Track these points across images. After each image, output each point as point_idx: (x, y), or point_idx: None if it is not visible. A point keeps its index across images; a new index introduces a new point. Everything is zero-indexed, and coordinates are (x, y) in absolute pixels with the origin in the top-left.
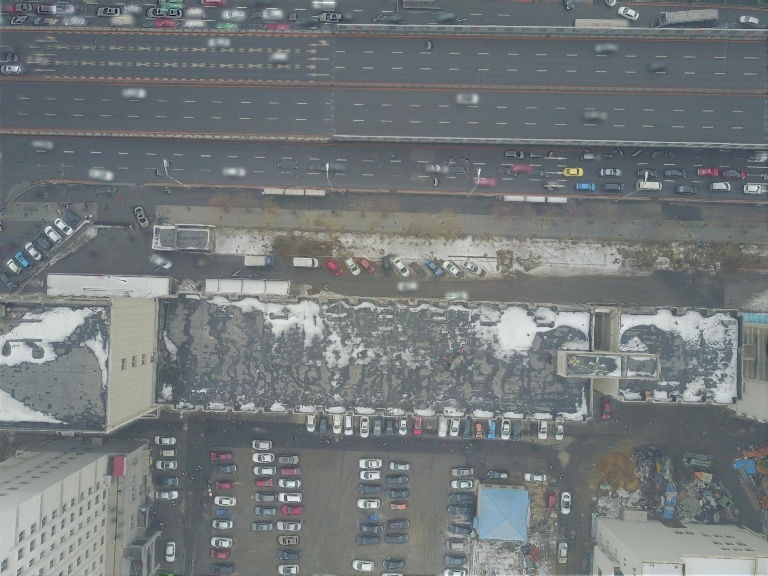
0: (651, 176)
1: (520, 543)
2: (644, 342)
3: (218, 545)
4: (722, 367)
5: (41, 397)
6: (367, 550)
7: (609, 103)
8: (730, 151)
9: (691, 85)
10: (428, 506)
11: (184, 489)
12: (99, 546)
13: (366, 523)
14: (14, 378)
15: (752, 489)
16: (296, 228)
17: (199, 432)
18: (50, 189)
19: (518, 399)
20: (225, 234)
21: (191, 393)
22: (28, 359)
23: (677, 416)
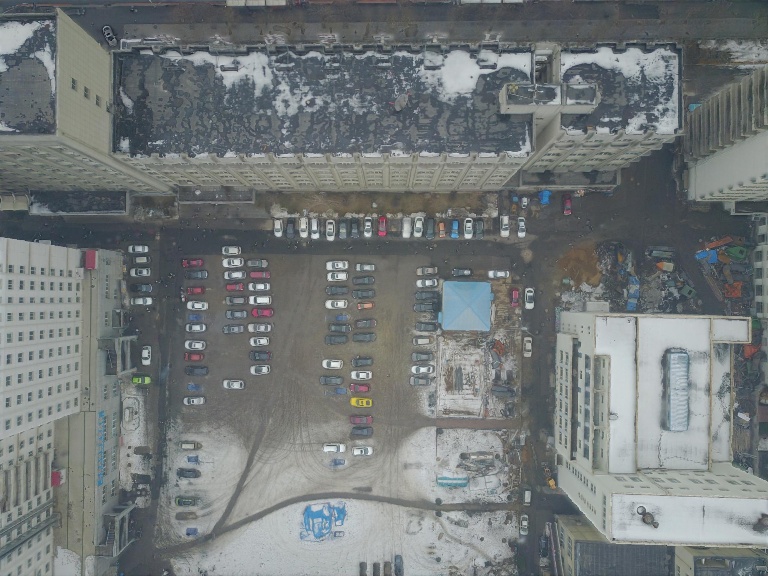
0: None
1: (485, 339)
2: (586, 80)
3: (191, 347)
4: (663, 102)
5: None
6: (336, 350)
7: None
8: None
9: None
10: (395, 306)
11: (158, 296)
12: (74, 334)
13: (334, 323)
14: None
15: (714, 279)
16: (259, 41)
17: (171, 241)
18: None
19: (463, 140)
20: None
21: (147, 145)
22: None
23: (638, 211)
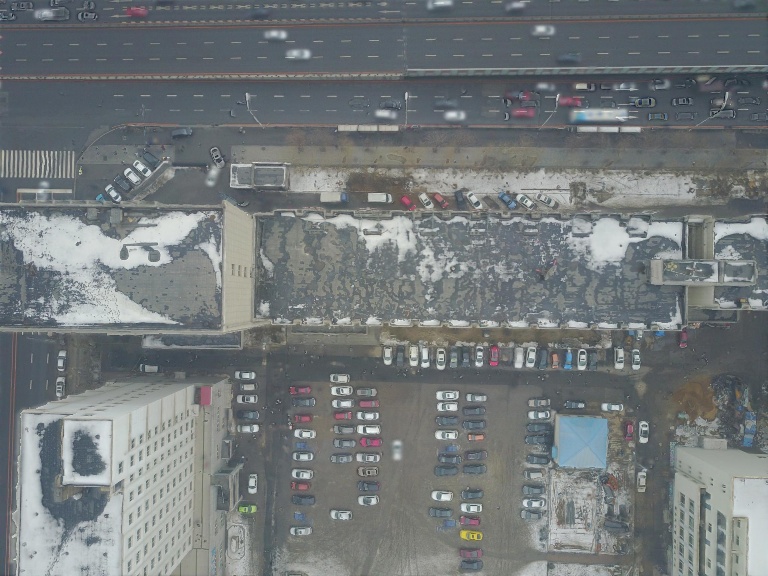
0: None
1: (598, 473)
2: (738, 251)
3: (299, 476)
4: None
5: (158, 299)
6: (445, 481)
7: (682, 30)
8: None
9: (766, 9)
10: (505, 437)
11: (264, 423)
12: (189, 473)
13: (444, 454)
14: (132, 281)
15: None
16: (369, 165)
17: (278, 367)
18: (128, 132)
19: (611, 310)
20: (299, 172)
21: (288, 309)
22: (145, 262)
23: (755, 345)
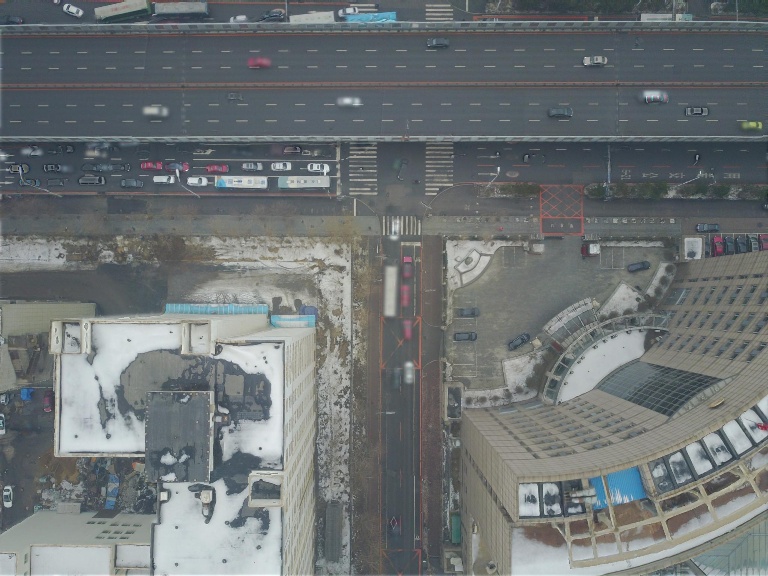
0: (94, 171)
1: None
2: None
3: None
4: None
5: None
6: None
7: (33, 100)
8: (175, 144)
9: (110, 80)
10: None
11: None
12: None
13: None
14: None
15: None
16: None
17: None
18: None
19: None
20: None
21: None
22: None
23: None
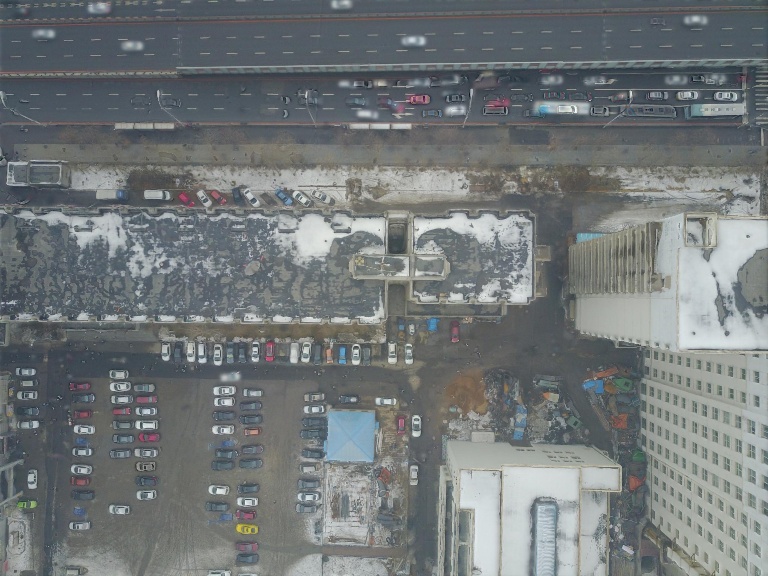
0: (497, 101)
1: (372, 466)
2: (440, 245)
3: (77, 472)
4: (517, 268)
5: None
6: (223, 475)
7: (449, 28)
8: (577, 74)
9: (529, 7)
10: (282, 432)
11: (45, 419)
12: None
13: (221, 449)
14: None
15: (601, 409)
16: (149, 162)
17: (59, 363)
18: None
19: (317, 304)
20: (80, 170)
21: (1, 305)
22: None
23: (527, 339)
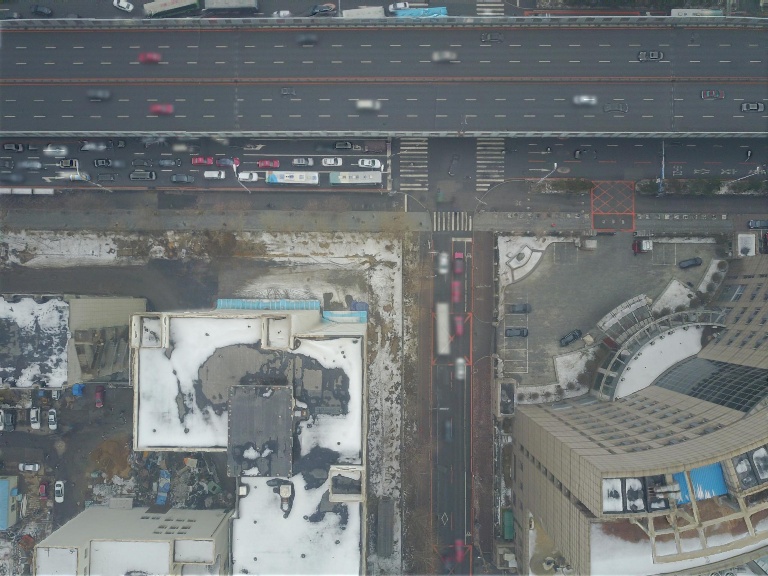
0: (144, 166)
1: (15, 533)
2: None
3: None
4: (57, 352)
5: None
6: None
7: (86, 94)
8: (225, 139)
9: (163, 75)
10: None
11: None
12: None
13: None
14: None
15: None
16: None
17: None
18: None
19: None
20: None
21: None
22: None
23: None
